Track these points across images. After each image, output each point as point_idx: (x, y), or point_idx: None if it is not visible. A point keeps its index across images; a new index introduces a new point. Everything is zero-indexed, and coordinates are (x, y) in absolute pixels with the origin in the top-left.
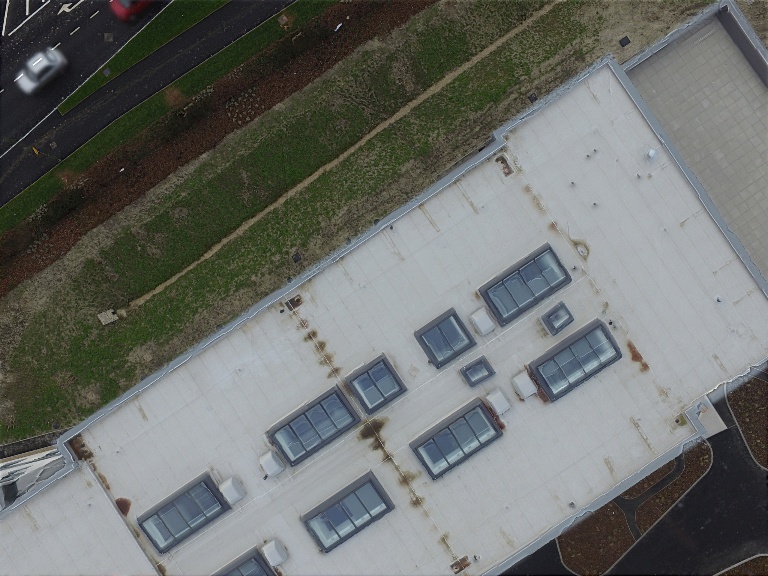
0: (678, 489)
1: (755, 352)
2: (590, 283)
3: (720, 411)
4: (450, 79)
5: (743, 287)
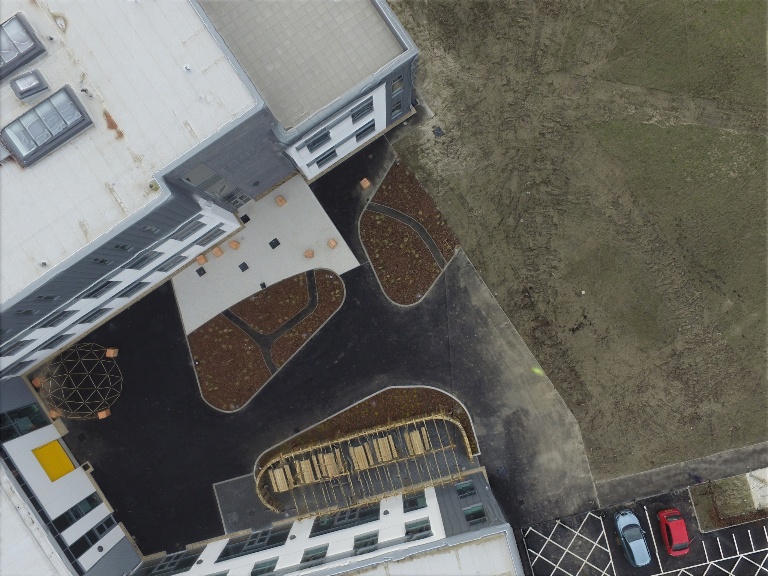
0: (312, 324)
1: (222, 118)
2: (68, 54)
3: (353, 248)
4: None
5: (211, 56)
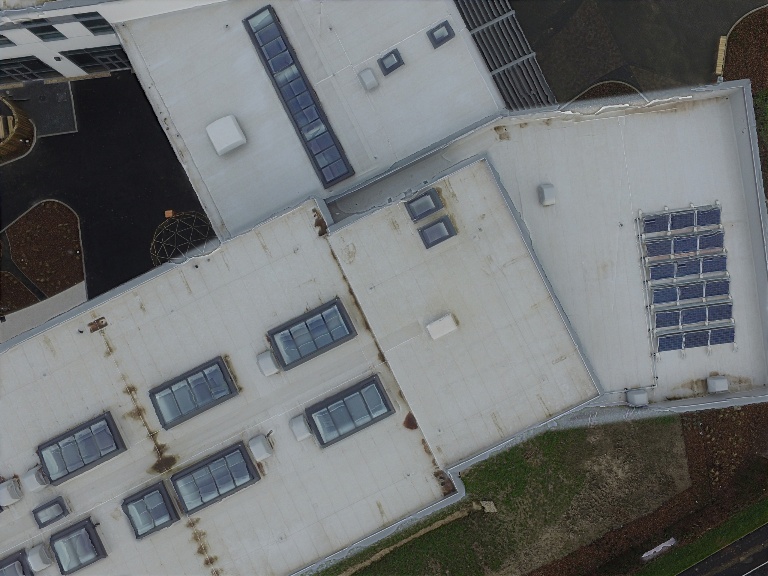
0: None
1: None
2: None
3: None
4: None
5: None
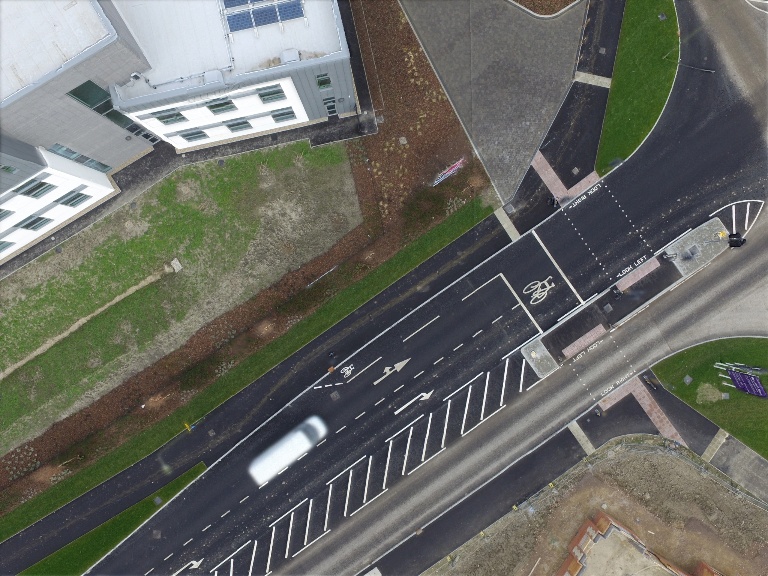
0: None
1: None
2: None
3: None
4: None
5: None
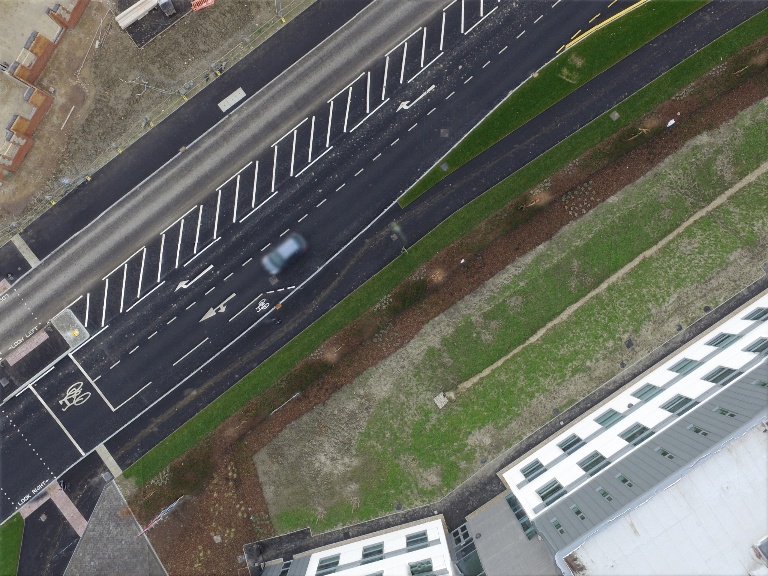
0: None
1: None
2: None
3: None
4: (765, 168)
5: None
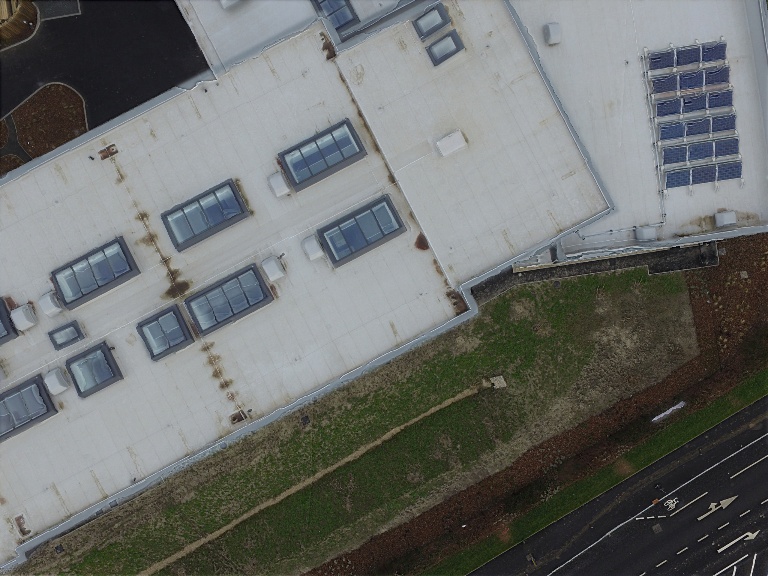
0: None
1: None
2: None
3: None
4: (142, 574)
5: None
